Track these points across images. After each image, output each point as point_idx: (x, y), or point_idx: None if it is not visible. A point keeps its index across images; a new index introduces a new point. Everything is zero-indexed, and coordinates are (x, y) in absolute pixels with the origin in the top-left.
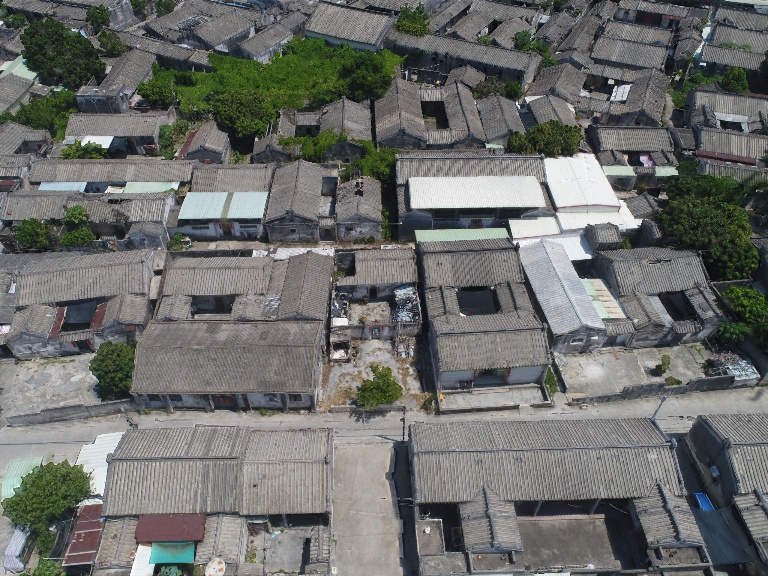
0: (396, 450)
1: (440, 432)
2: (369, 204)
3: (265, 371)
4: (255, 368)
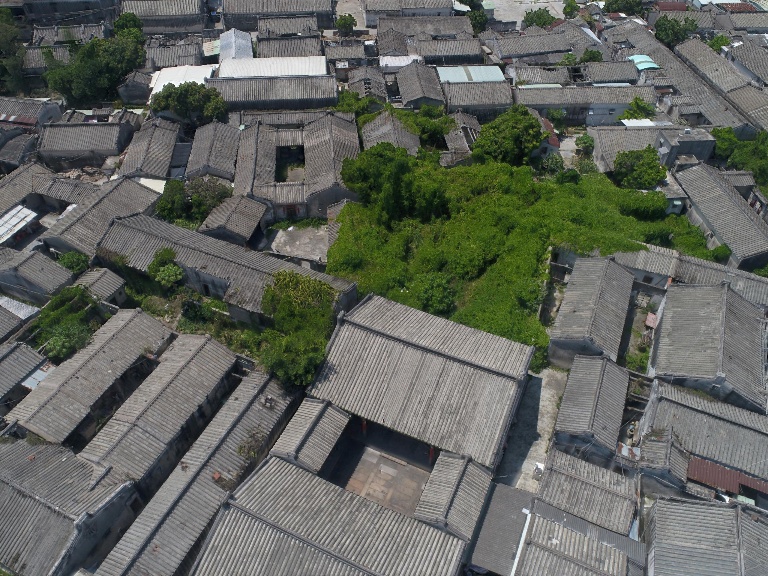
0: None
1: (319, 6)
2: (358, 77)
3: None
4: None
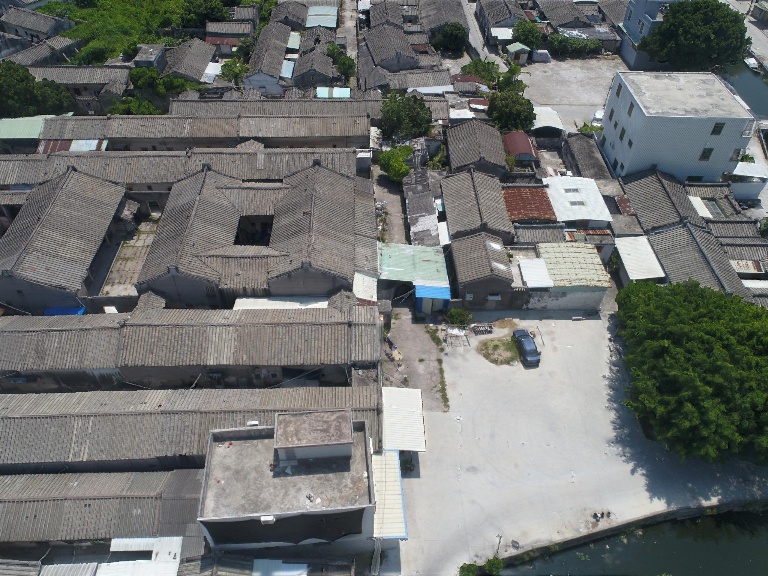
0: (473, 2)
1: None
2: None
3: (453, 3)
4: (452, 5)
